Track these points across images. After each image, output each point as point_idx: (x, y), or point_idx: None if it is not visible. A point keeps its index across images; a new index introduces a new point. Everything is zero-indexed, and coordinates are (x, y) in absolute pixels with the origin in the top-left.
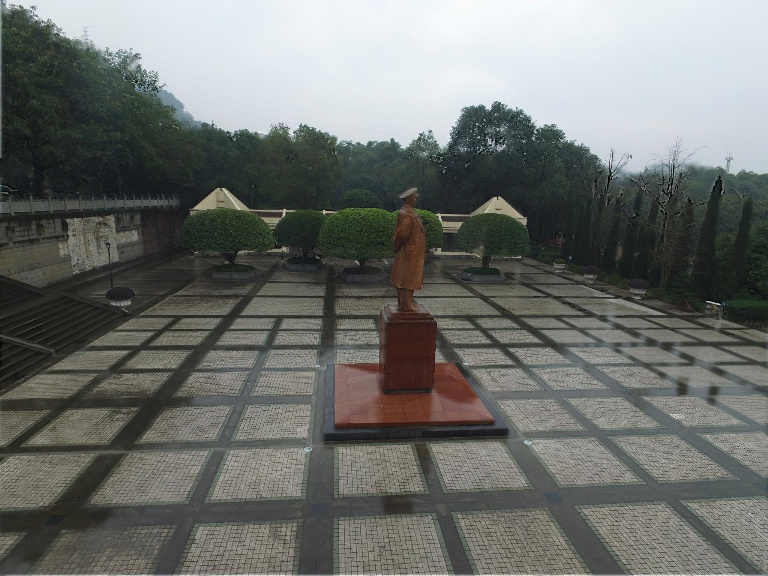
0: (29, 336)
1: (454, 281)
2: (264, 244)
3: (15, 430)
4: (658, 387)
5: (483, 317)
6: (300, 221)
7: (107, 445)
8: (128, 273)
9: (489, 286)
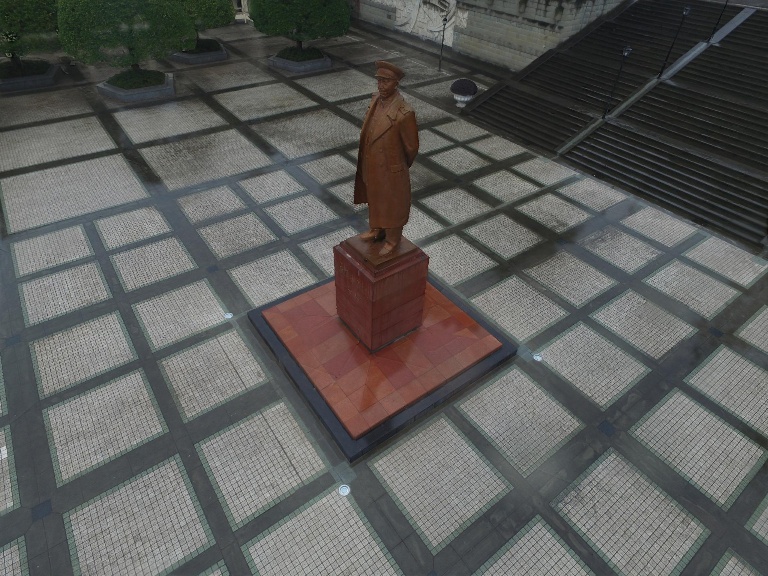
0: None
1: None
2: None
3: (577, 197)
4: None
5: None
6: None
7: (513, 207)
8: None
9: None
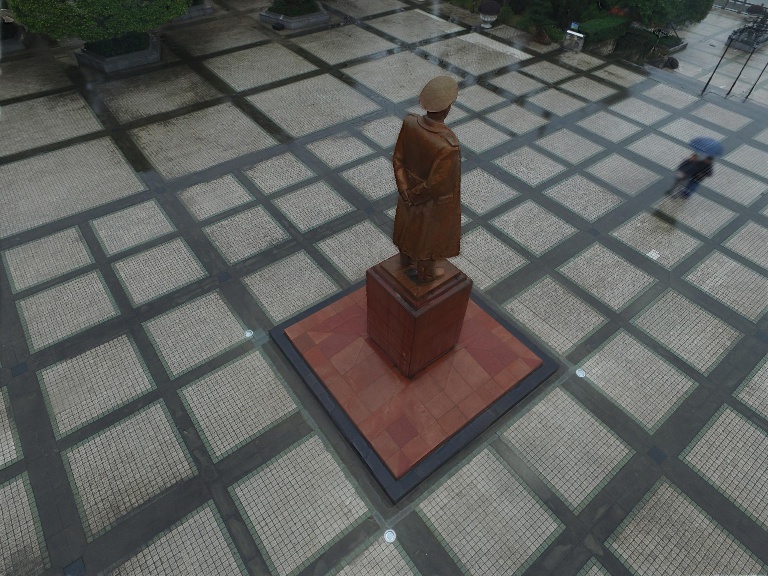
0: None
1: (266, 34)
2: None
3: None
4: (611, 209)
5: (365, 121)
6: None
7: None
8: None
9: (319, 38)
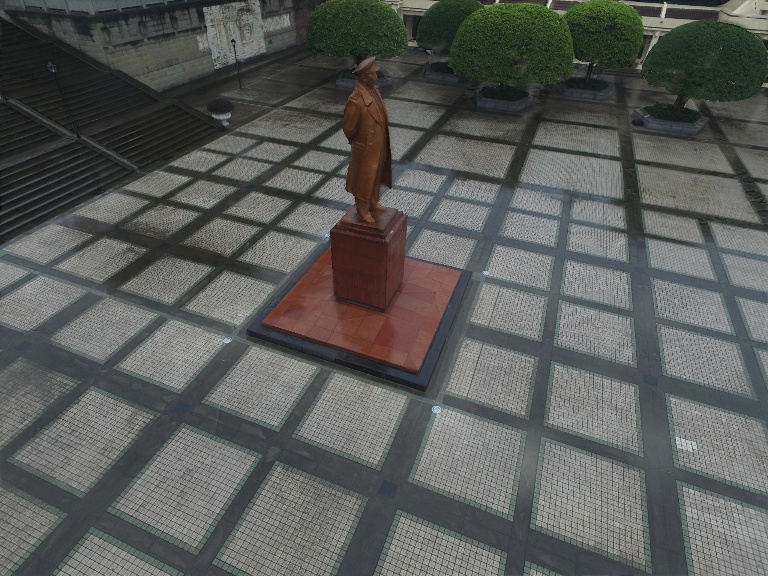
0: (124, 149)
1: (619, 124)
2: (389, 49)
3: (60, 250)
4: (716, 387)
5: (590, 198)
6: (444, 15)
7: (99, 284)
8: (268, 68)
9: (661, 141)
